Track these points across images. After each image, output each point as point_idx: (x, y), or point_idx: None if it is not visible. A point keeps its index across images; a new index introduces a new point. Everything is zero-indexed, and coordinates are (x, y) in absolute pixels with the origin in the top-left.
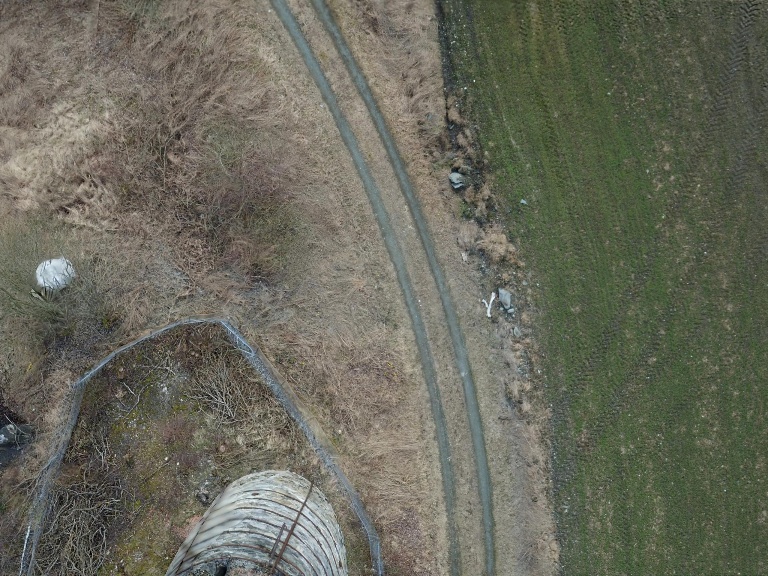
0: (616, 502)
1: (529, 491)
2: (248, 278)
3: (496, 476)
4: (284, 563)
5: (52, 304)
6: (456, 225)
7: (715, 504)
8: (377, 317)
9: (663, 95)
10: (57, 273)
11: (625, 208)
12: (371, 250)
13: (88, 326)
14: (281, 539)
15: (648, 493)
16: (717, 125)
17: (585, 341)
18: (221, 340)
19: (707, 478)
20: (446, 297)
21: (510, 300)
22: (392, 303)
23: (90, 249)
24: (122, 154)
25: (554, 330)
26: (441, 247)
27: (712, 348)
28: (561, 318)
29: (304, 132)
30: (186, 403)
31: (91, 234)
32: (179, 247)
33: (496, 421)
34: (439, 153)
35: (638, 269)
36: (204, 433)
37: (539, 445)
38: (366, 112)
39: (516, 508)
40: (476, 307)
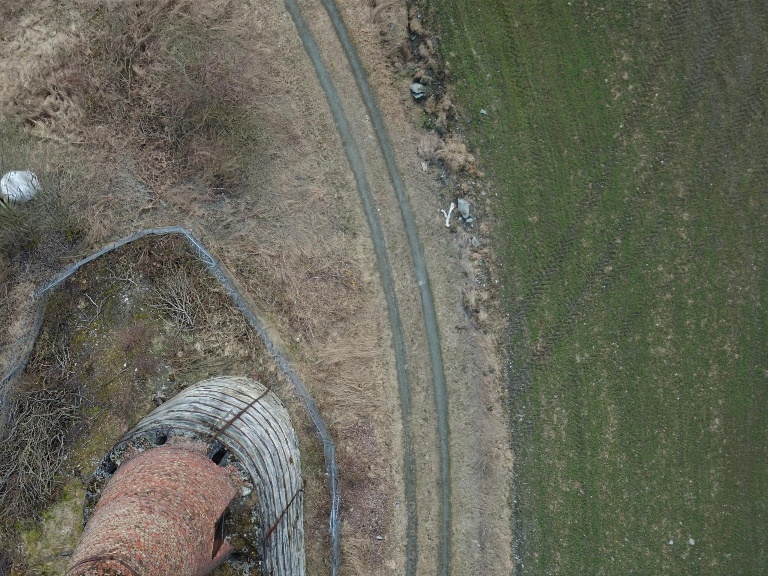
0: (570, 411)
1: (485, 400)
2: (211, 190)
3: (452, 385)
4: (225, 437)
5: (15, 213)
6: (416, 135)
7: (668, 412)
8: (336, 226)
9: (623, 4)
10: (21, 184)
11: (583, 117)
12: (331, 159)
13: (52, 239)
14: (226, 419)
15: (602, 401)
16: (675, 34)
17: (542, 250)
18: (183, 251)
19: (660, 386)
20: (405, 206)
21: (469, 210)
22: (351, 212)
23: (55, 162)
24: (88, 66)
25: (512, 240)
26: (401, 157)
27: (667, 256)
28: (519, 228)
29: (267, 42)
30: (146, 312)
31: (57, 147)
32: (143, 160)
33: (453, 330)
34: (401, 64)
35: (595, 178)
36: (163, 340)
37: (495, 354)
38: (329, 22)
39: (472, 417)
40: (435, 217)
